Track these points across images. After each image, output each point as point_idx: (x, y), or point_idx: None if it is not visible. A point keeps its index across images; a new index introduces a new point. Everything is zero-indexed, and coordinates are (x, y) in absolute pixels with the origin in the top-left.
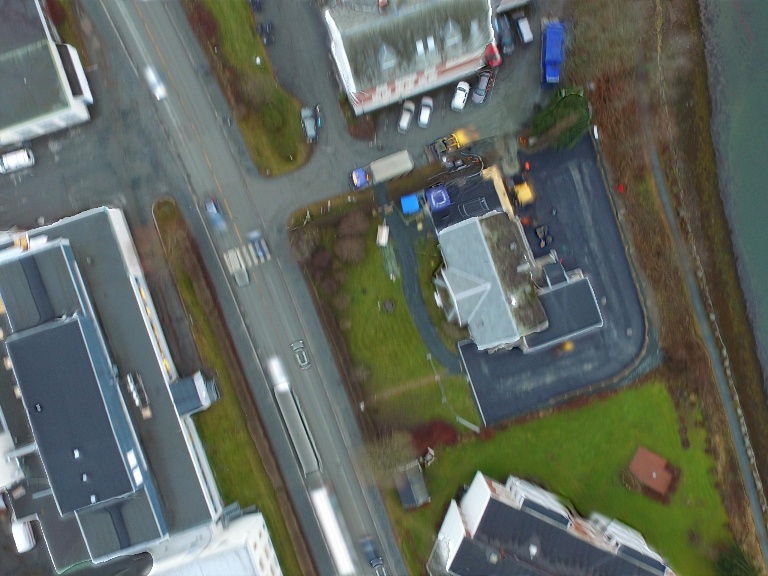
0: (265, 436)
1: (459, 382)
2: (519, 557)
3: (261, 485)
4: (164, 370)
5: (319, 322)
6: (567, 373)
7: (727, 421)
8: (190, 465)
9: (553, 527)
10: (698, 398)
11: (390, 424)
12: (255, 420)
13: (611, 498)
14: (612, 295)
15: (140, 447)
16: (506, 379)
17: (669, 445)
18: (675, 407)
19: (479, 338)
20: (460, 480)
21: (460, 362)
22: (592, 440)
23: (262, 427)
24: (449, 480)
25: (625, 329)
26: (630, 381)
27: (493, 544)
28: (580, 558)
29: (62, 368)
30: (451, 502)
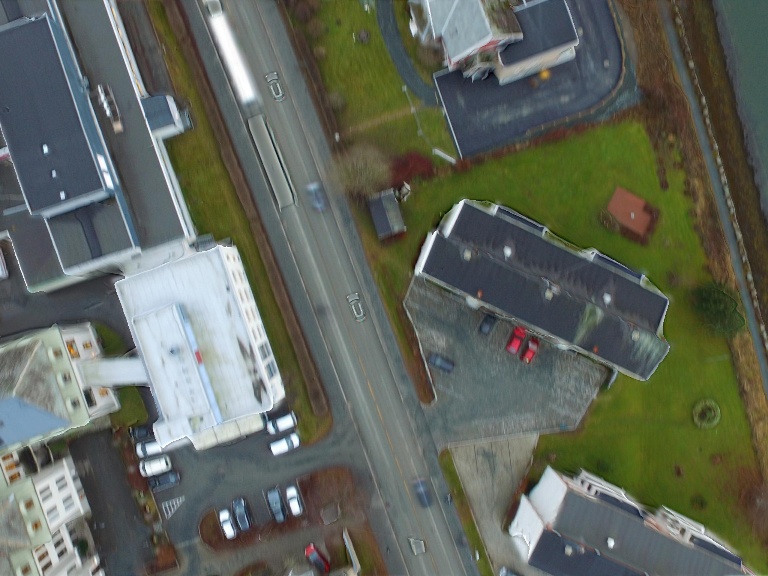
0: (239, 166)
1: (435, 114)
2: (493, 255)
3: (236, 218)
4: (136, 86)
5: (293, 53)
6: (544, 105)
7: (707, 170)
8: (162, 180)
9: (528, 233)
10: (677, 139)
11: (365, 156)
12: (229, 148)
13: (589, 236)
14: (589, 26)
15: (112, 162)
16: (482, 112)
17: (647, 186)
18: (653, 148)
19: (453, 49)
20: (436, 210)
21: (436, 93)
22: (570, 179)
23: (236, 158)
24: (425, 213)
25: (602, 61)
26: (607, 116)
27: (467, 243)
28: (555, 262)
29: (31, 65)
30: (427, 235)
